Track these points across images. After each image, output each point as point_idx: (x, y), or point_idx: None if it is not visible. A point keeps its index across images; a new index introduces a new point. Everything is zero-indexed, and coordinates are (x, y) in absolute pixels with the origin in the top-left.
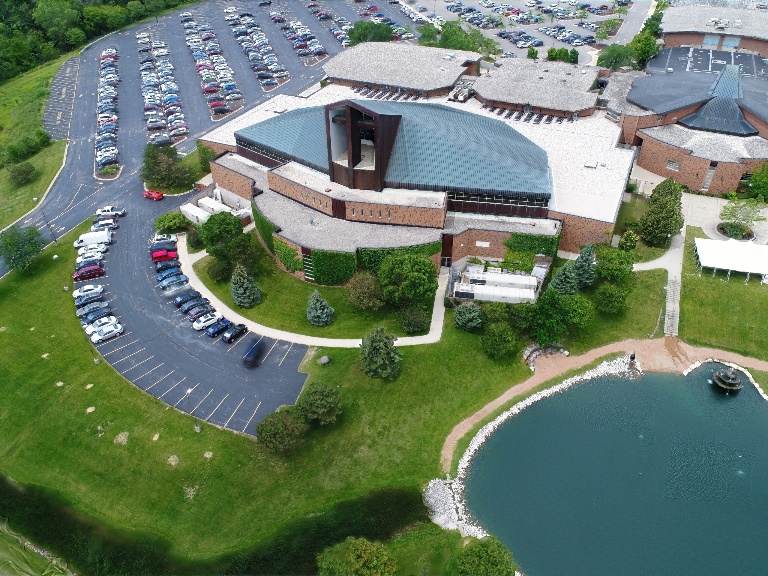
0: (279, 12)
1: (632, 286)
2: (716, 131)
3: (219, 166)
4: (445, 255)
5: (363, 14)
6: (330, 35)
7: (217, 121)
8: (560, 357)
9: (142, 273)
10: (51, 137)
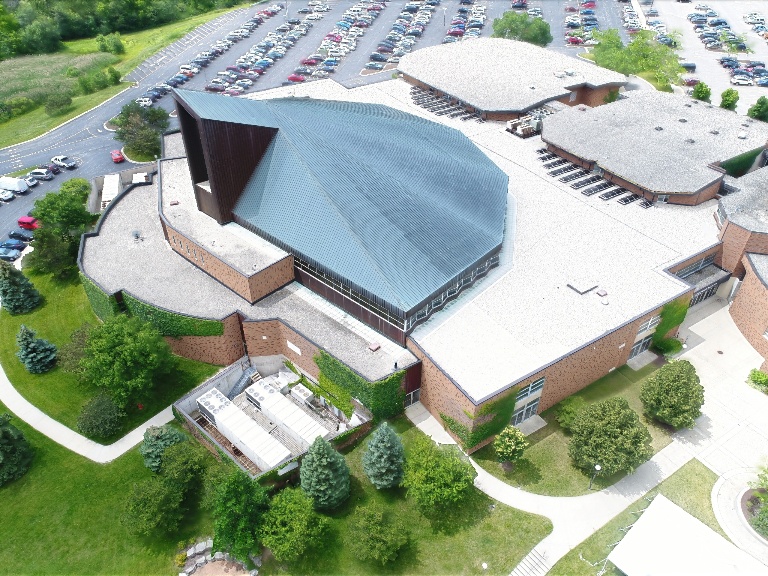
0: None
1: (465, 525)
2: None
3: None
4: None
5: (569, 8)
6: None
7: None
8: None
9: (1, 234)
10: (120, 77)
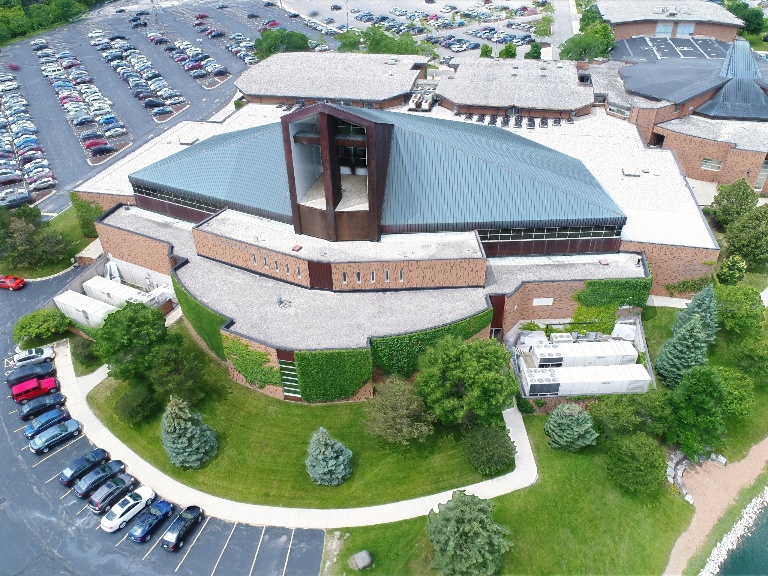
0: (159, 33)
1: (757, 334)
2: (744, 119)
3: (111, 228)
4: (492, 326)
5: (262, 29)
6: (228, 53)
7: (97, 165)
8: (715, 468)
9: None
10: None
